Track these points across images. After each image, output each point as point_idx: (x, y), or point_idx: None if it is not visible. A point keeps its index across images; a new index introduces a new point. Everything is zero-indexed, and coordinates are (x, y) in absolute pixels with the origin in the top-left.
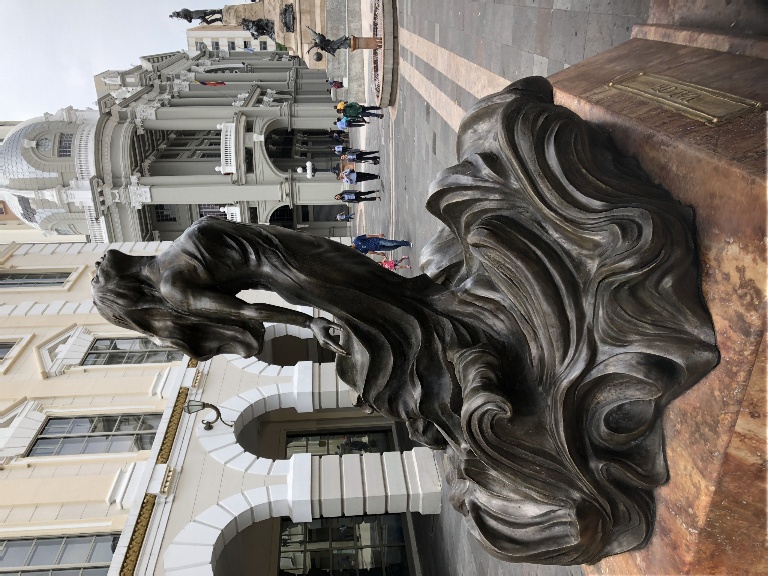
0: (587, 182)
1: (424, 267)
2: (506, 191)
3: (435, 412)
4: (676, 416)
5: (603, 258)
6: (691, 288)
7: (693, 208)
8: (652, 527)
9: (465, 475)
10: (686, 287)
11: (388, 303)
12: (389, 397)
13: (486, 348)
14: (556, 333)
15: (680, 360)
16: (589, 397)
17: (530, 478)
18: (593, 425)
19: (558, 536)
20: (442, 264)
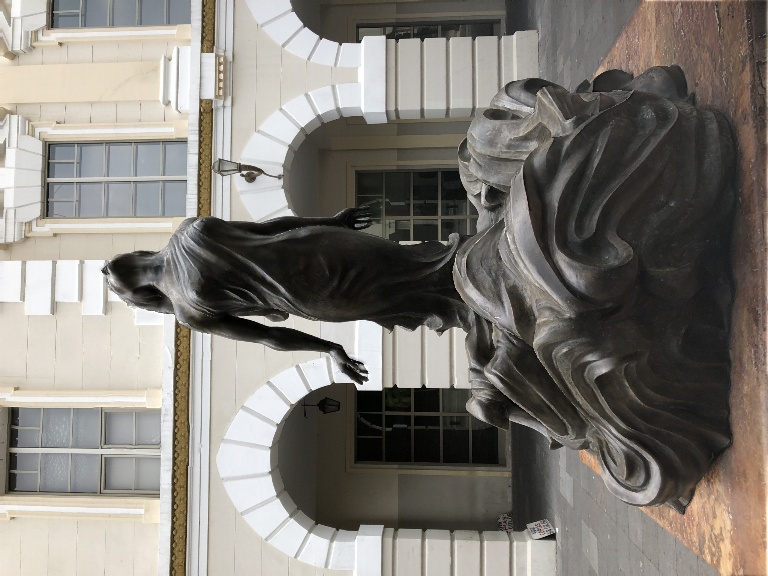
0: (625, 395)
1: None
2: None
3: None
4: None
5: (607, 458)
6: None
7: (731, 442)
8: None
9: None
10: None
11: None
12: None
13: None
14: None
15: None
16: None
17: None
18: None
19: None
20: (489, 181)
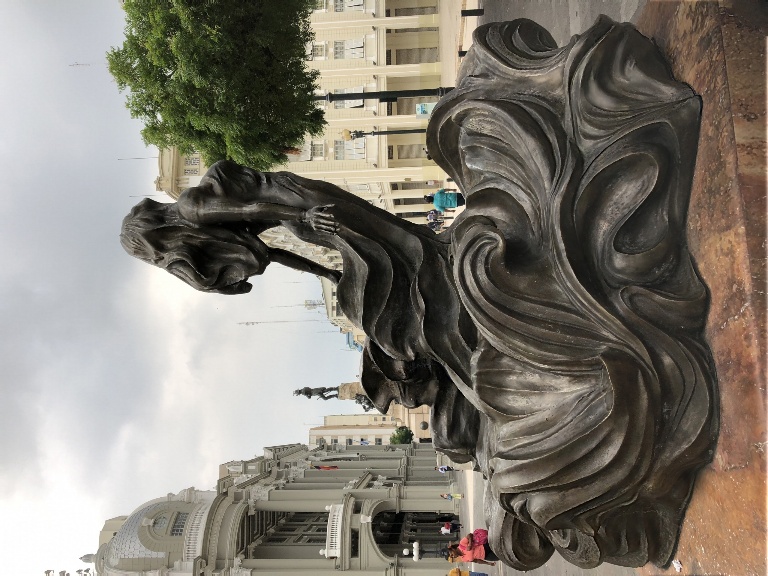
0: None
1: None
2: (487, 89)
3: (445, 347)
4: (694, 218)
5: None
6: None
7: (652, 39)
8: (715, 382)
9: (479, 400)
10: (654, 72)
11: (389, 222)
12: (393, 330)
13: None
14: (539, 154)
15: (663, 120)
16: (593, 229)
17: (544, 344)
18: (605, 261)
19: (594, 423)
20: None
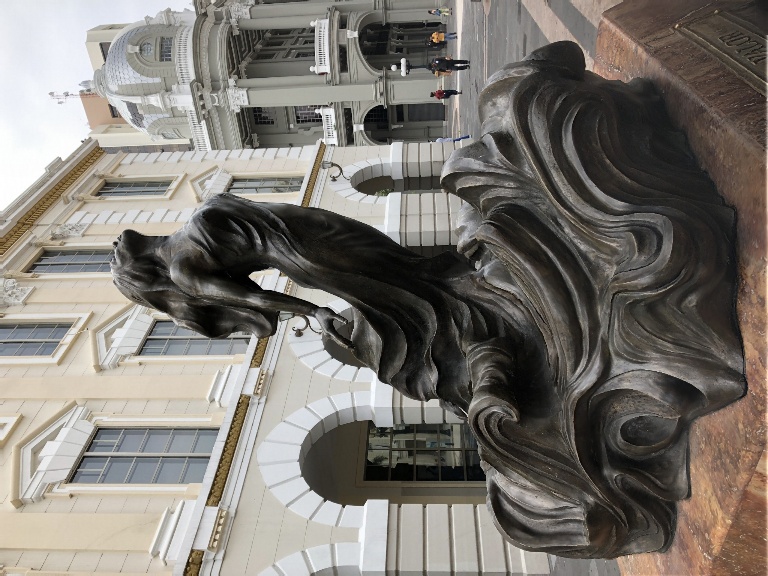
0: (610, 175)
1: (458, 233)
2: (521, 180)
3: (455, 394)
4: (701, 434)
5: (618, 269)
6: (722, 306)
7: (735, 210)
8: (672, 536)
9: None
10: (715, 305)
11: (401, 288)
12: (407, 378)
13: (497, 345)
14: (567, 342)
15: (701, 386)
16: (606, 405)
17: (542, 477)
18: (610, 433)
19: (572, 533)
20: None
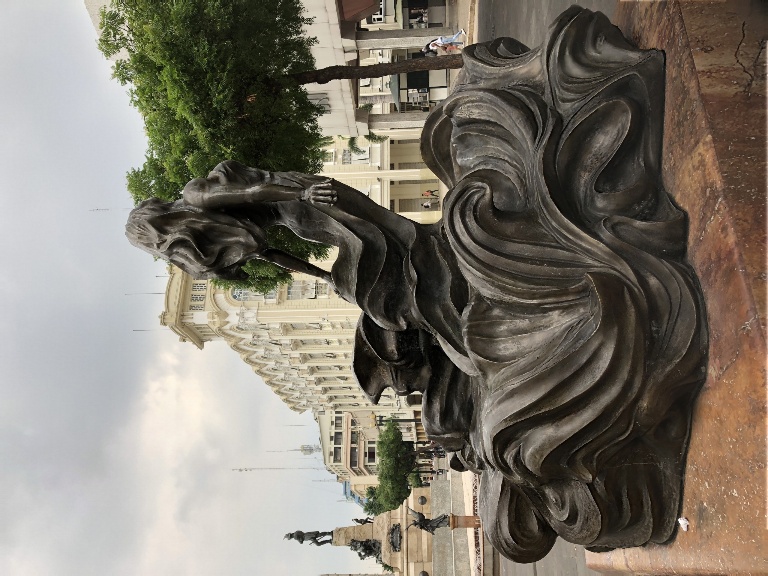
0: None
1: None
2: None
3: (437, 317)
4: (668, 158)
5: None
6: None
7: None
8: (700, 294)
9: (470, 352)
10: None
11: None
12: (385, 303)
13: None
14: (522, 121)
15: None
16: (575, 180)
17: (532, 279)
18: (588, 204)
19: None
20: None
